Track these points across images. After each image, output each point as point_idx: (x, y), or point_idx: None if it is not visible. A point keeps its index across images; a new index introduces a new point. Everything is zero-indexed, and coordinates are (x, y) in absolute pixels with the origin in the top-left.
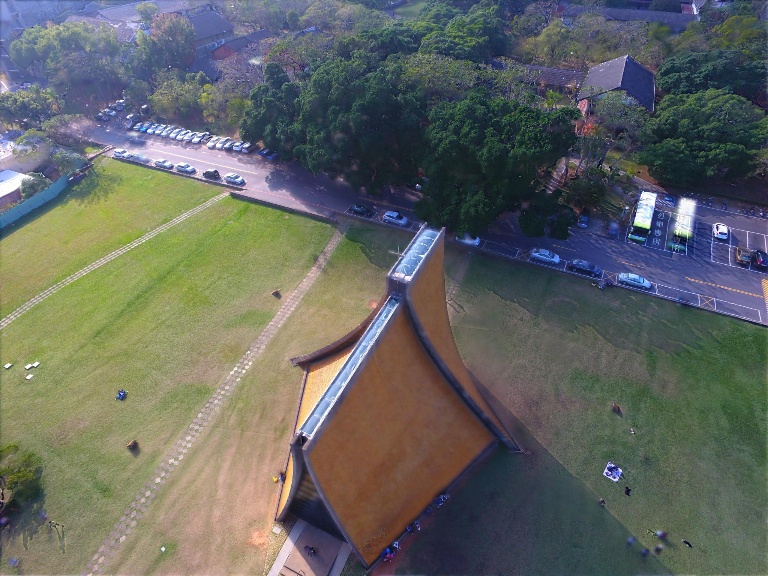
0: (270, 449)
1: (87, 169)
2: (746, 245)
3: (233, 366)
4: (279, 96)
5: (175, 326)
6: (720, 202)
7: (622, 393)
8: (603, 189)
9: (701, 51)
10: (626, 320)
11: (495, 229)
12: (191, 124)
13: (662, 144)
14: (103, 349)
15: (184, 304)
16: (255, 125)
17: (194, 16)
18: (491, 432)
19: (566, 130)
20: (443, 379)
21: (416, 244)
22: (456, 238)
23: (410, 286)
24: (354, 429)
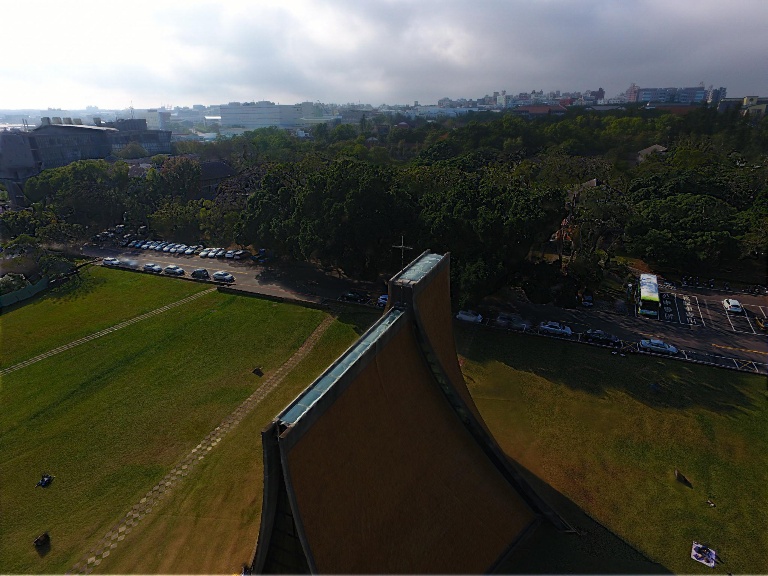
0: (233, 538)
1: (72, 275)
2: (764, 317)
3: (196, 443)
4: (275, 199)
5: (133, 405)
6: (721, 285)
7: (682, 460)
8: (601, 272)
9: (661, 172)
10: (661, 384)
11: (497, 309)
12: (186, 241)
13: (649, 234)
14: (37, 431)
15: (148, 383)
16: (250, 226)
17: (203, 163)
18: (529, 506)
19: (556, 207)
20: (461, 426)
21: (420, 263)
22: (457, 316)
23: (417, 291)
24: (351, 453)
